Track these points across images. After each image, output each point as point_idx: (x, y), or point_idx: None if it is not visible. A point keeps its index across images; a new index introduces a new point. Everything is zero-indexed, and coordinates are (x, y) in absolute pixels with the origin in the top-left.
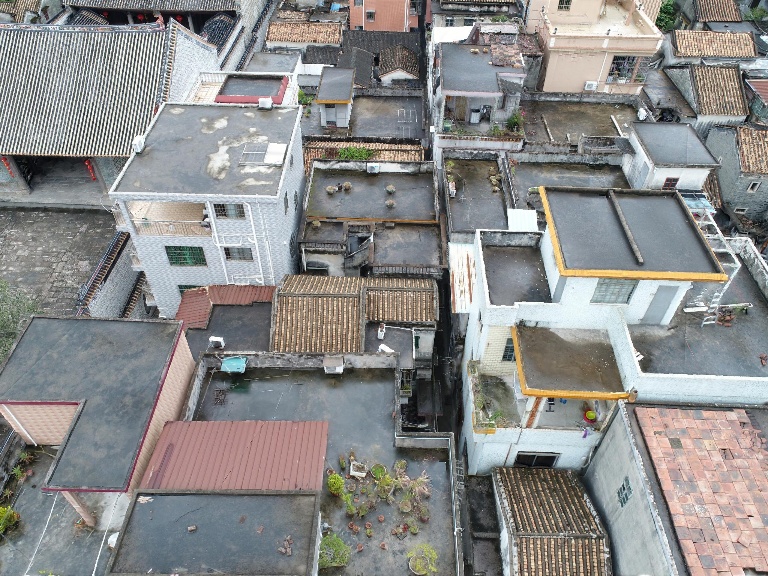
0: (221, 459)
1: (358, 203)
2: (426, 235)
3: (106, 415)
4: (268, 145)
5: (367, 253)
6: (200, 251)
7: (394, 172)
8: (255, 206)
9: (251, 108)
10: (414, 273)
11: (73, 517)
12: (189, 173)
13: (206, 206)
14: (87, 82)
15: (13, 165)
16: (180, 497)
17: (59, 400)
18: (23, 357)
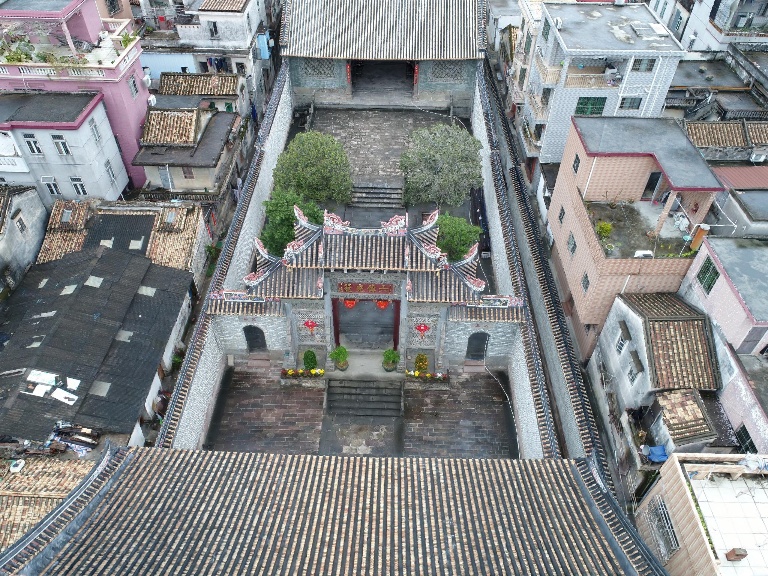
0: (761, 180)
1: (683, 78)
2: (744, 98)
3: (675, 159)
4: (649, 24)
5: (708, 108)
6: (603, 101)
7: (694, 60)
8: (664, 60)
9: (608, 5)
10: (755, 117)
11: (640, 232)
12: (607, 40)
13: (629, 61)
14: (416, 3)
15: (350, 72)
16: (760, 191)
17: (639, 152)
18: (590, 134)
